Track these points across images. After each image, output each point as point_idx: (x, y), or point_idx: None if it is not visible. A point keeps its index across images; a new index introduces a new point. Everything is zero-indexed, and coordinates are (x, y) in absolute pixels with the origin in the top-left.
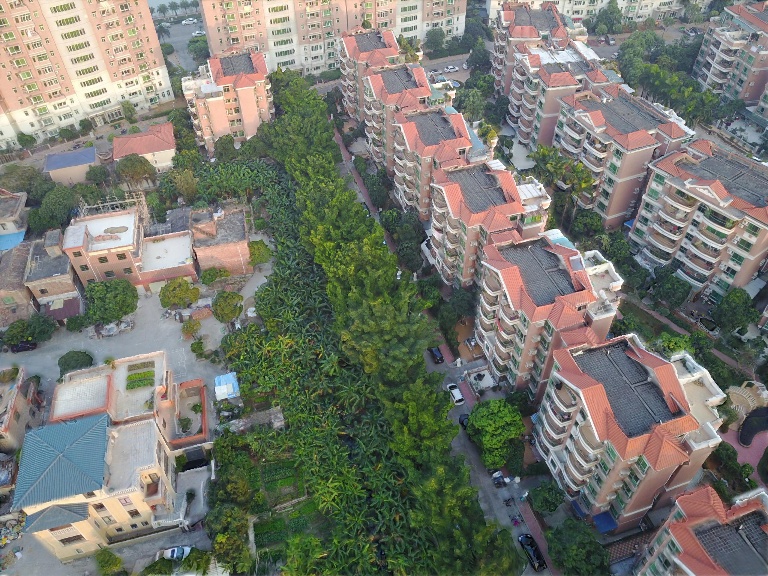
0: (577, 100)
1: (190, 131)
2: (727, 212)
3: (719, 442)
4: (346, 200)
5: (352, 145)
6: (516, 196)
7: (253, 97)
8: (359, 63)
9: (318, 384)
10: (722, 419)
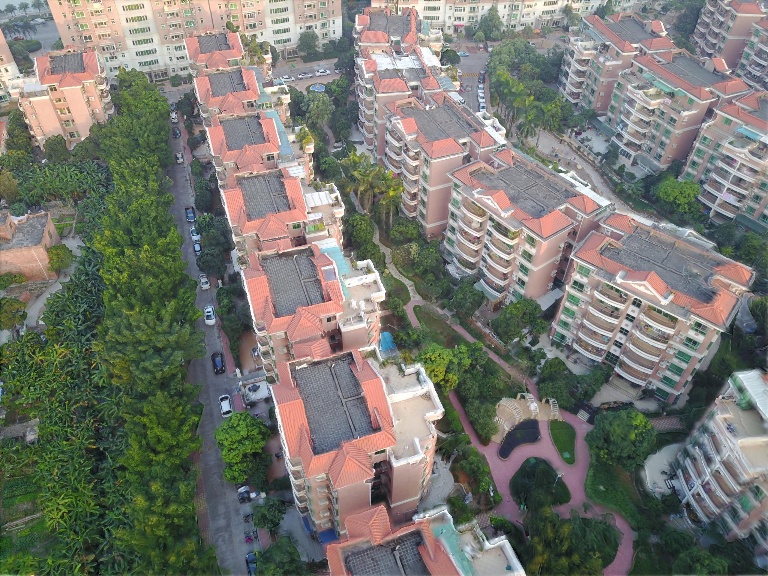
0: (401, 107)
1: (24, 131)
2: (506, 223)
3: (420, 458)
4: (152, 205)
5: (198, 148)
6: (301, 204)
7: (81, 97)
8: (198, 65)
9: (82, 395)
10: (433, 434)
